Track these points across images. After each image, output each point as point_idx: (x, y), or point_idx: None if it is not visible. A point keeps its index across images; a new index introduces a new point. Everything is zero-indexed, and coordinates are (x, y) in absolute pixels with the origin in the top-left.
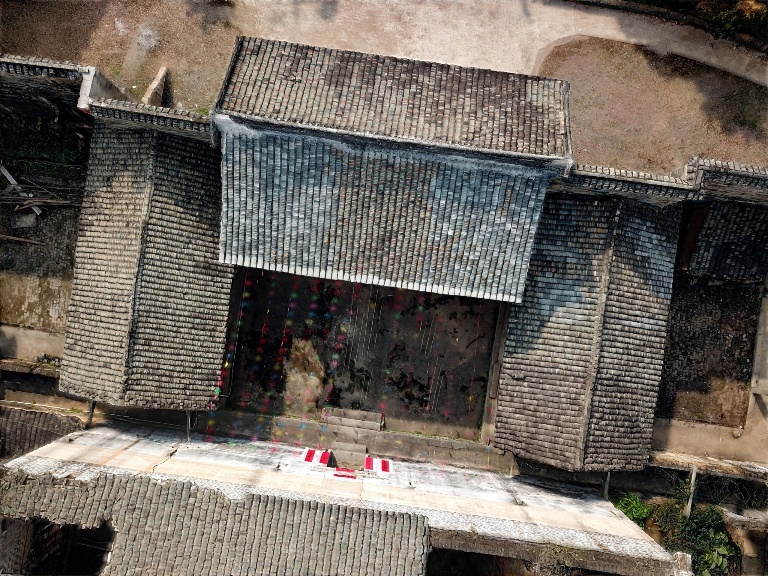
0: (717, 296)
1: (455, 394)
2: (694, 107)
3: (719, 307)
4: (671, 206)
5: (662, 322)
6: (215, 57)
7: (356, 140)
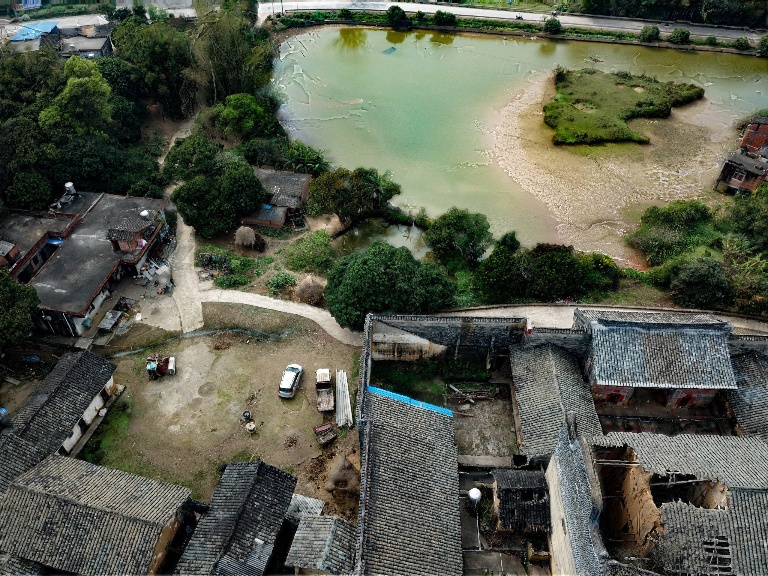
0: None
1: None
2: None
3: None
4: None
5: None
6: None
7: (647, 326)
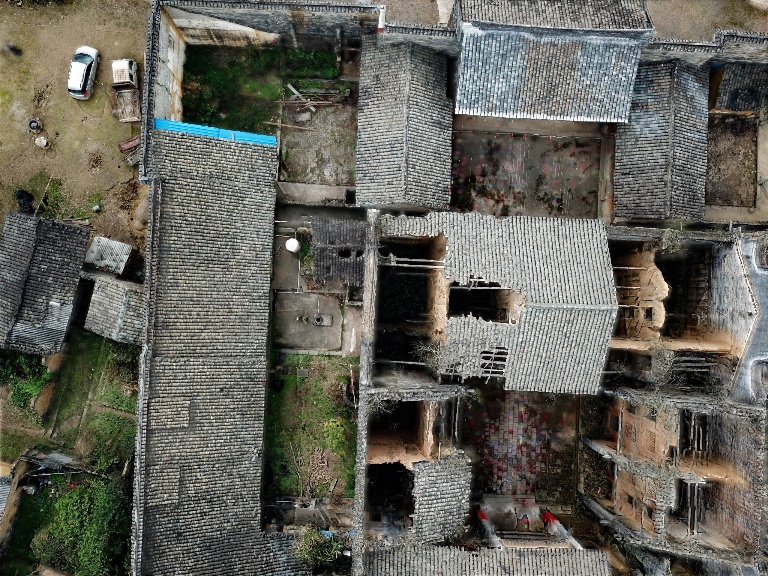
0: (731, 128)
1: (578, 202)
2: (706, 15)
3: (733, 135)
4: (703, 66)
5: (704, 134)
6: (409, 7)
7: (539, 31)
